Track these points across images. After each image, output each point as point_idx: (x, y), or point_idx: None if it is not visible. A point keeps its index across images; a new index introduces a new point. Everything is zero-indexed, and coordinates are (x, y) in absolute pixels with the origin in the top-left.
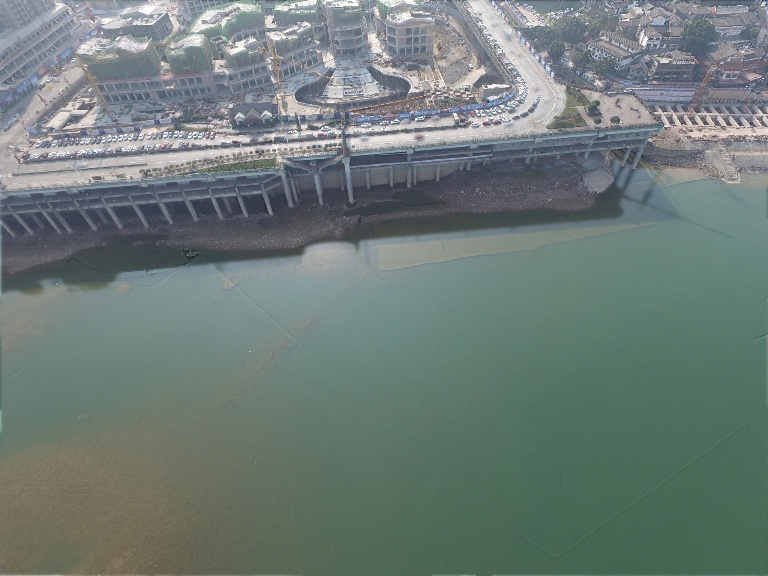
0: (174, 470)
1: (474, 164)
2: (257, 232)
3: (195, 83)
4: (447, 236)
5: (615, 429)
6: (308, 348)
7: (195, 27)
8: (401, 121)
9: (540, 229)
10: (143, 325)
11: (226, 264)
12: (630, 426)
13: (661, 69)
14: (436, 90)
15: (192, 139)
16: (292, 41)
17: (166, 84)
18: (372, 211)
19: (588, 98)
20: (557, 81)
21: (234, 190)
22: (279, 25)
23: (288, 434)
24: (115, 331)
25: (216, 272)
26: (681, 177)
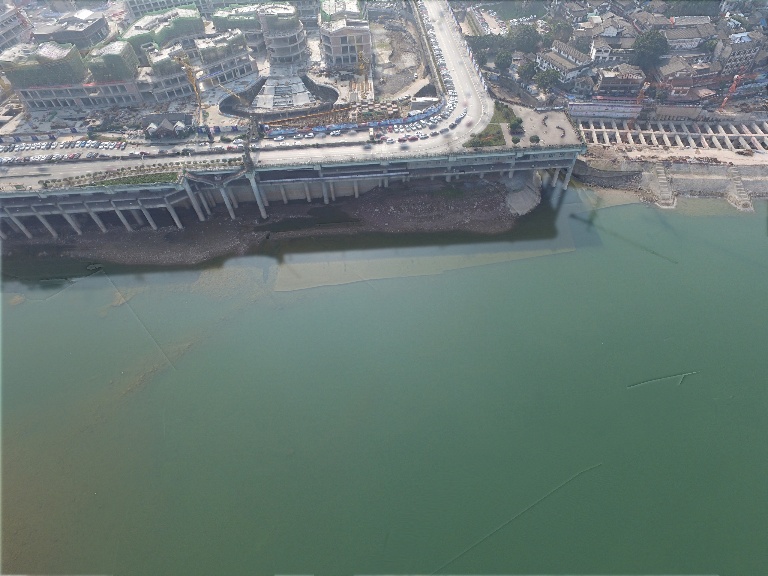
0: (12, 497)
1: (394, 181)
2: (161, 246)
3: (118, 91)
4: (352, 257)
5: (447, 484)
6: (181, 372)
7: (128, 33)
8: (316, 135)
9: (450, 252)
10: (28, 339)
11: (123, 279)
12: (461, 483)
13: (606, 83)
14: (363, 102)
15: (103, 149)
16: (220, 49)
17: (90, 91)
18: (283, 227)
19: (516, 114)
20: (489, 95)
21: (137, 203)
22: (218, 31)
23: (136, 464)
24: (0, 345)
25: (111, 287)
26: (613, 200)
